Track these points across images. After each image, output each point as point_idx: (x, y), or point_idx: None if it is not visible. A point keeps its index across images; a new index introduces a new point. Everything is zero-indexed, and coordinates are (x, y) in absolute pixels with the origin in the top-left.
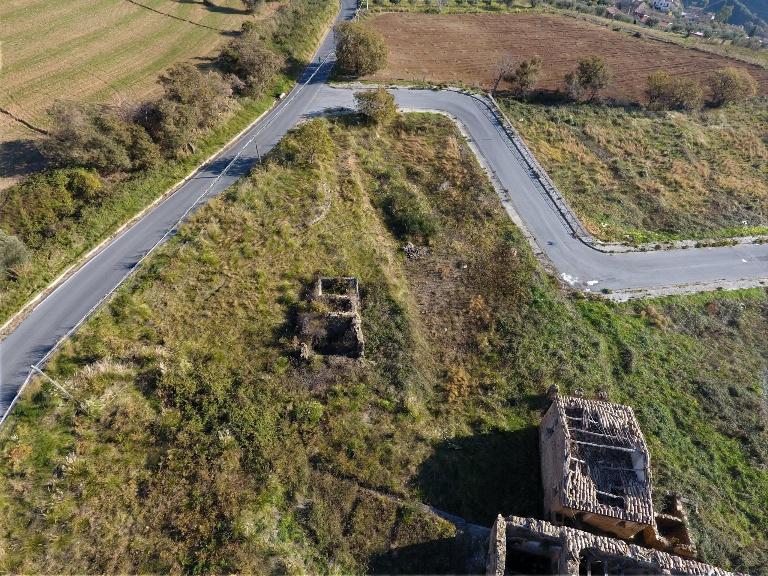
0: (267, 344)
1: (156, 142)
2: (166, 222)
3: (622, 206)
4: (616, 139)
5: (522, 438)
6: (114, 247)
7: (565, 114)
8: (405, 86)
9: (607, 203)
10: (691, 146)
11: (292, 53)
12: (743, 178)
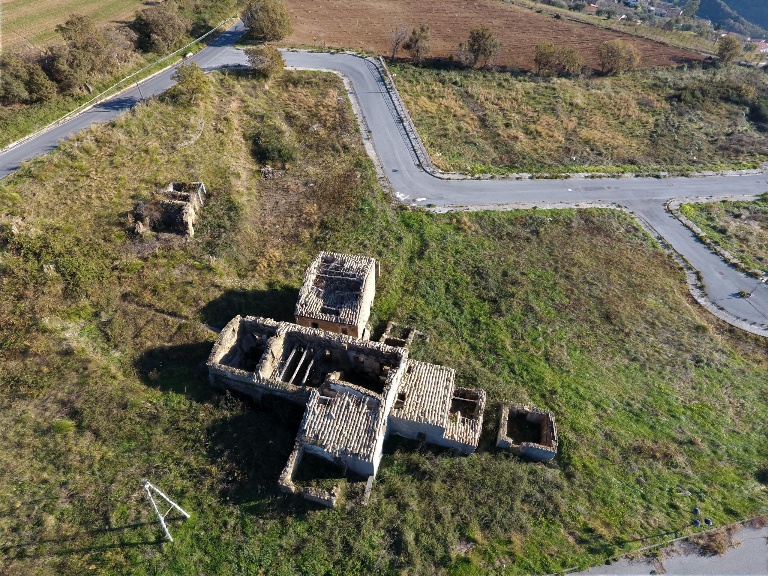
0: (112, 224)
1: (55, 81)
2: (52, 141)
3: (477, 148)
4: (495, 98)
5: None
6: (3, 156)
7: (453, 77)
8: (305, 50)
9: (464, 145)
10: (566, 105)
11: (207, 21)
12: (605, 131)
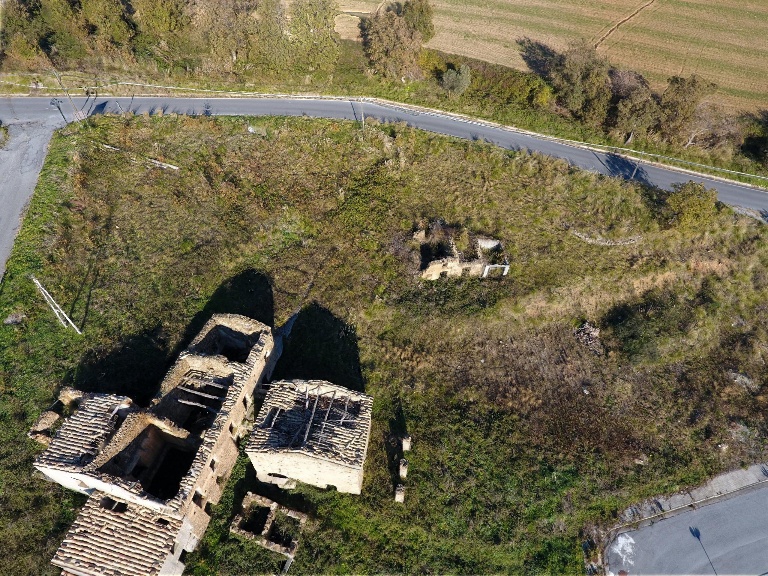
0: (424, 216)
1: None
2: (528, 146)
3: None
4: None
5: None
6: (492, 129)
7: None
8: None
9: None
10: None
11: None
12: None
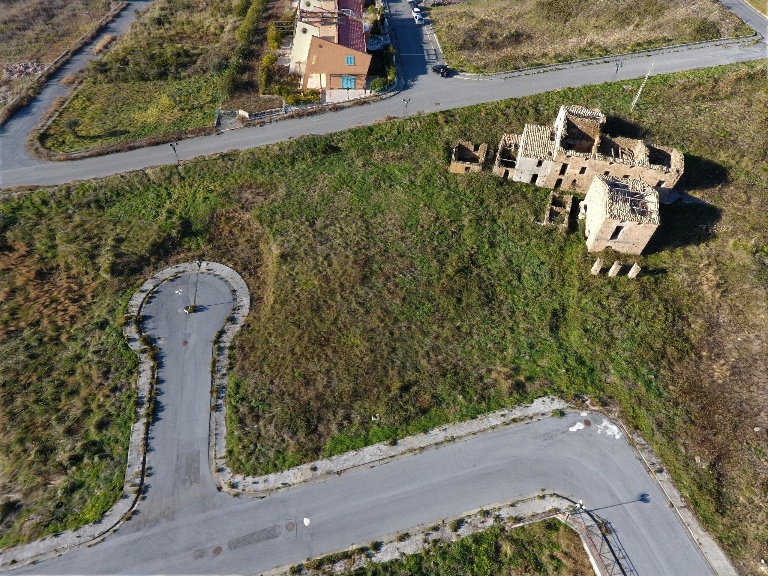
0: None
1: None
2: None
3: None
4: None
5: (652, 245)
6: None
7: None
8: None
9: None
10: None
11: None
12: None
